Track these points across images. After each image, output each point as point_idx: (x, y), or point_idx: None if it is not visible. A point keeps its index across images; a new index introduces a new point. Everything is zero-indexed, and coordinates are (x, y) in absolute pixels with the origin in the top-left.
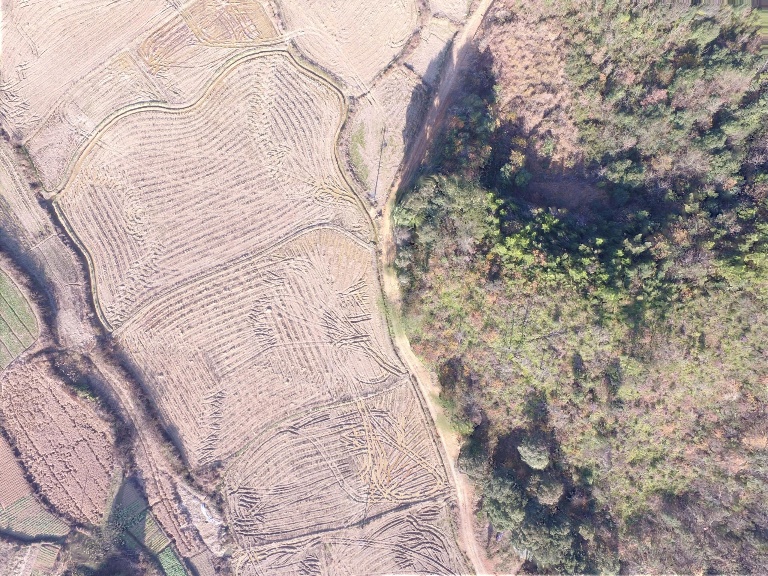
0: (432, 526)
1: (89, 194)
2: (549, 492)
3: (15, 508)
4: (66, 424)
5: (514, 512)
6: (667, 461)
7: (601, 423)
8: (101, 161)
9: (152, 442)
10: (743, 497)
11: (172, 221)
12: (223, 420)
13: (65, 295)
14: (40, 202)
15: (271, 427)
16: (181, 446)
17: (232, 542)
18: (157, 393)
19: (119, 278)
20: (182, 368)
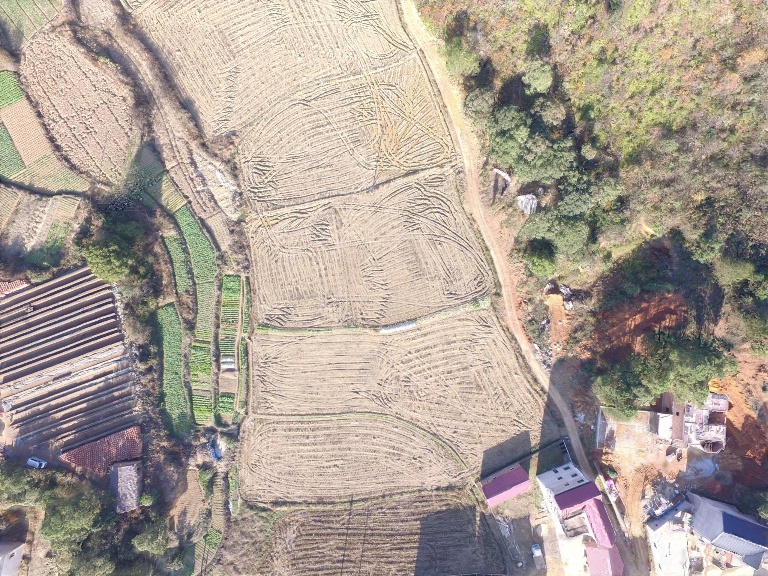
0: (439, 192)
1: None
2: (552, 104)
3: (37, 166)
4: (87, 88)
5: (519, 129)
6: (665, 91)
7: (602, 50)
8: None
9: (169, 109)
10: (739, 131)
11: None
12: (238, 93)
13: None
14: None
15: (284, 99)
16: (197, 117)
17: (246, 206)
18: (174, 69)
19: None
20: (198, 45)
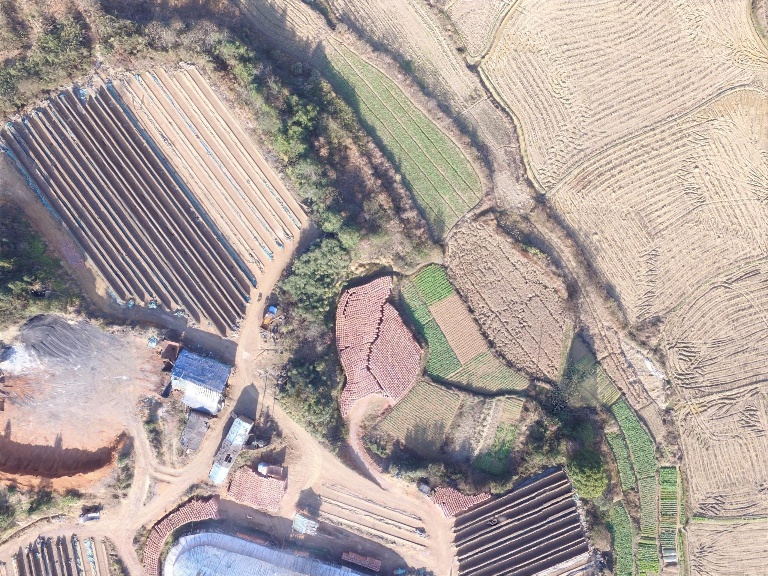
0: None
1: (514, 59)
2: None
3: (473, 364)
4: (518, 280)
5: None
6: None
7: None
8: (523, 26)
9: (597, 298)
10: None
11: (598, 84)
12: (659, 277)
13: (499, 157)
14: (467, 67)
15: (706, 282)
16: (620, 303)
17: (675, 394)
18: (592, 252)
19: (550, 140)
20: (616, 227)
